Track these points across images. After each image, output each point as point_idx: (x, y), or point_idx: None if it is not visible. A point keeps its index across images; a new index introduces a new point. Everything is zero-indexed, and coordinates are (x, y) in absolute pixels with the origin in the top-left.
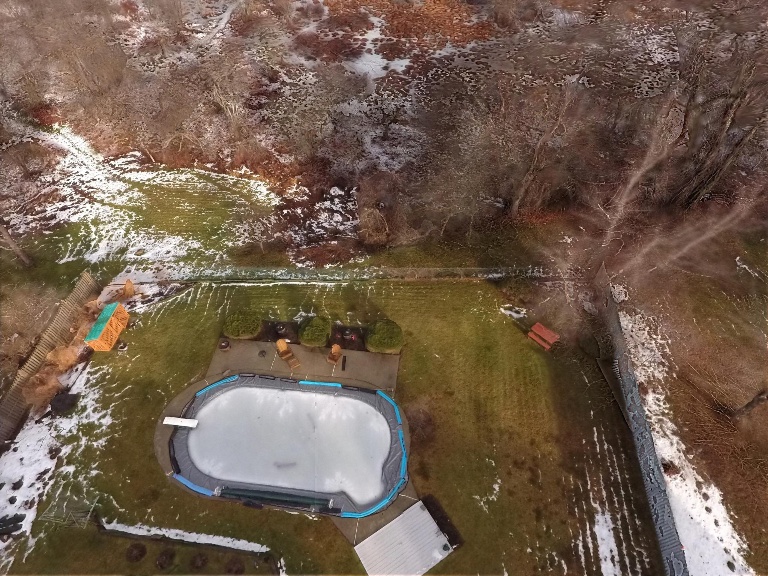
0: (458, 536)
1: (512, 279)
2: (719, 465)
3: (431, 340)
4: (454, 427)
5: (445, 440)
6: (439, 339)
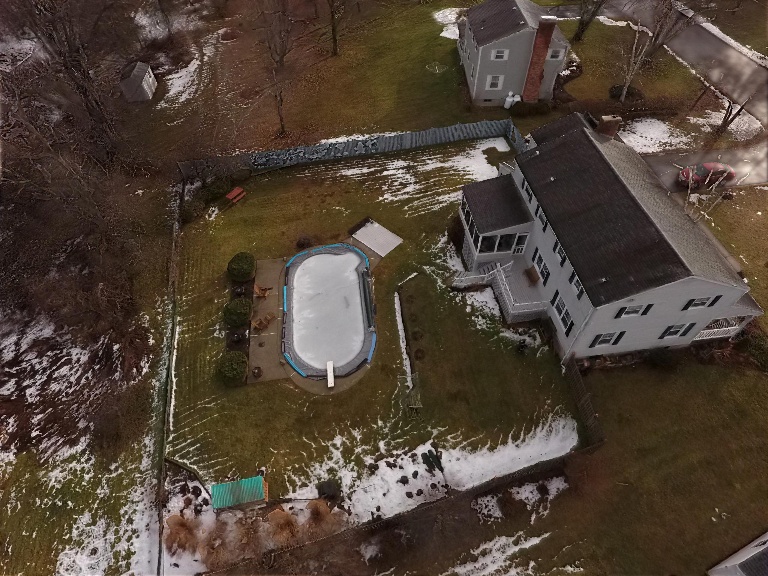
0: (366, 219)
1: (186, 208)
2: (310, 139)
3: (241, 248)
4: (306, 228)
5: (315, 230)
6: (240, 244)
